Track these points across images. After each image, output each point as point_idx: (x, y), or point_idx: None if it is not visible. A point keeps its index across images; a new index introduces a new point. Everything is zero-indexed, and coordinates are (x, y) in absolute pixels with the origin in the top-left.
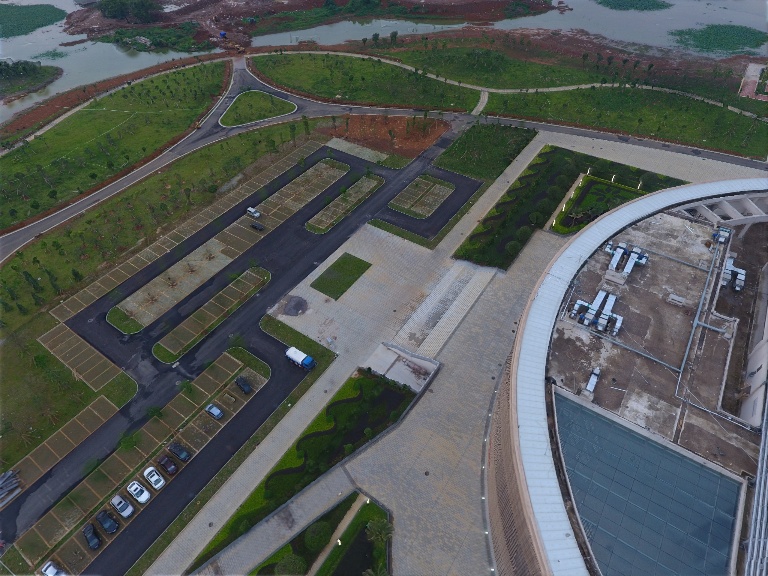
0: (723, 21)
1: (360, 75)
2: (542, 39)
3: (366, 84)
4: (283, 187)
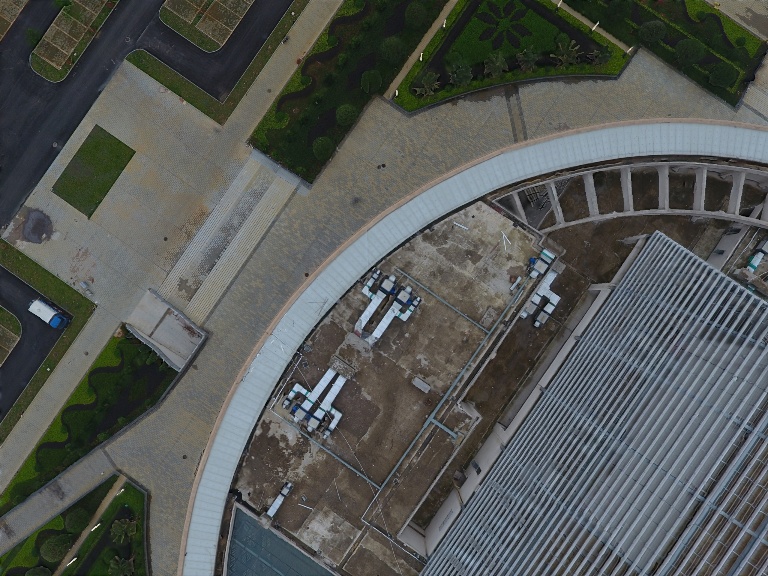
0: None
1: None
2: None
3: None
4: None
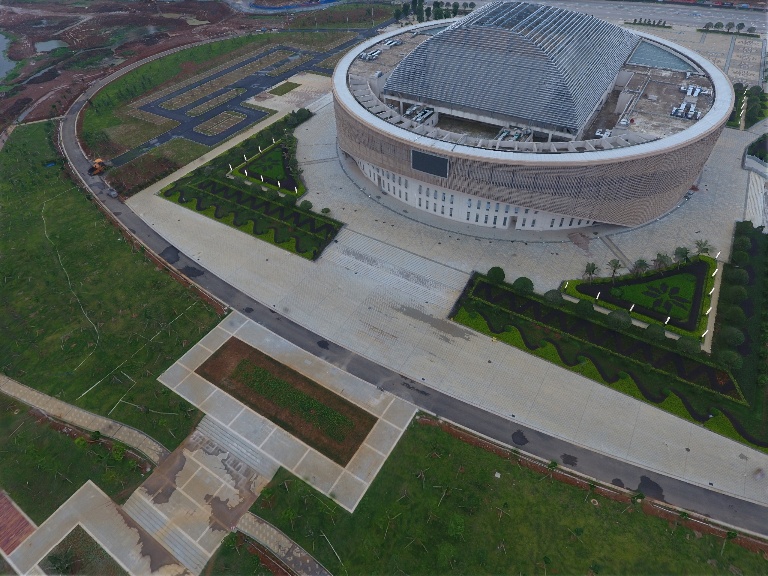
0: None
1: None
2: None
3: None
4: None
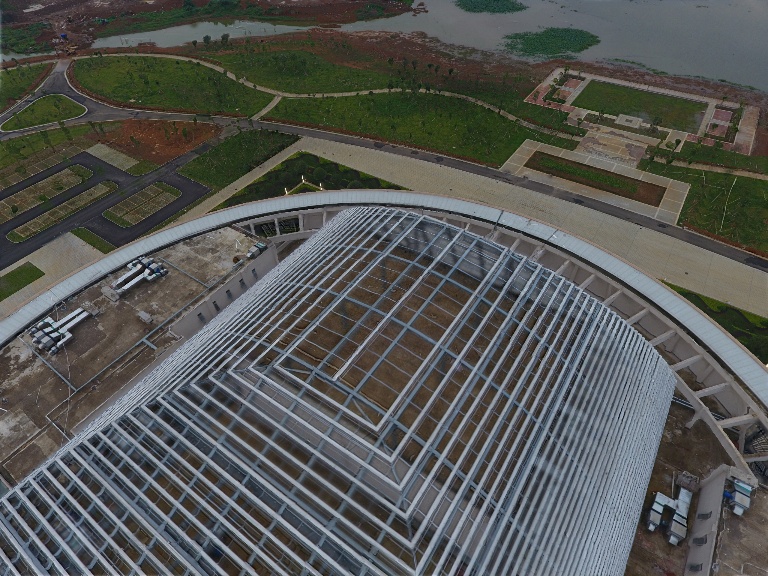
0: (563, 24)
1: (166, 79)
2: (376, 42)
3: (166, 88)
4: (14, 194)
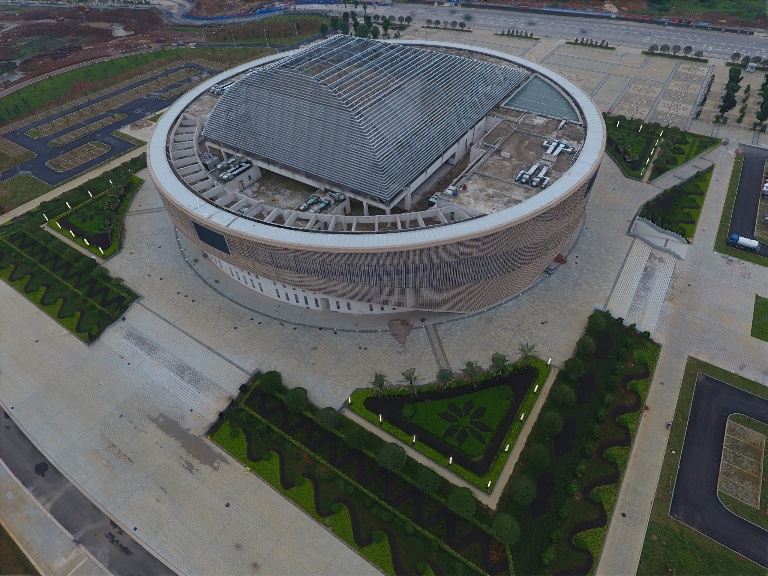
0: None
1: None
2: None
3: None
4: None
